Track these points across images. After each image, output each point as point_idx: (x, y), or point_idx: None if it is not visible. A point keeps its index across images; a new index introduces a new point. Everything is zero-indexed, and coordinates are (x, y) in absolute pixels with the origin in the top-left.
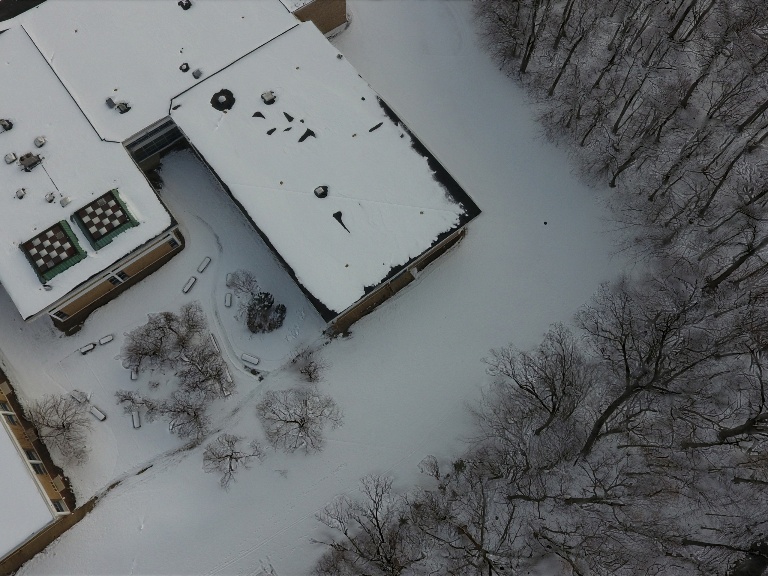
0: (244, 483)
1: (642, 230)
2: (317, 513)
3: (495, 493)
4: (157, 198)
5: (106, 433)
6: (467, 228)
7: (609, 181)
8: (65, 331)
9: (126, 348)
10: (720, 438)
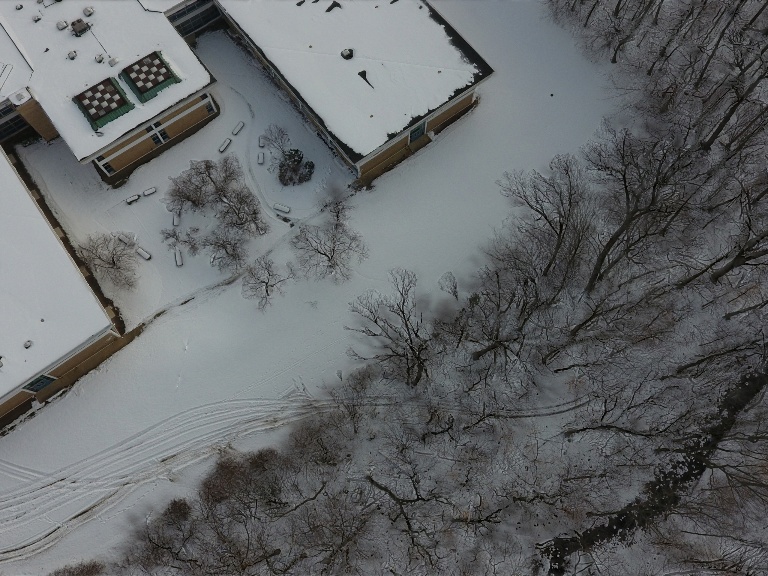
0: (278, 312)
1: (641, 98)
2: None
3: (507, 325)
4: (197, 59)
5: (151, 270)
6: (480, 98)
7: (611, 57)
8: (112, 184)
9: (169, 193)
10: (712, 280)
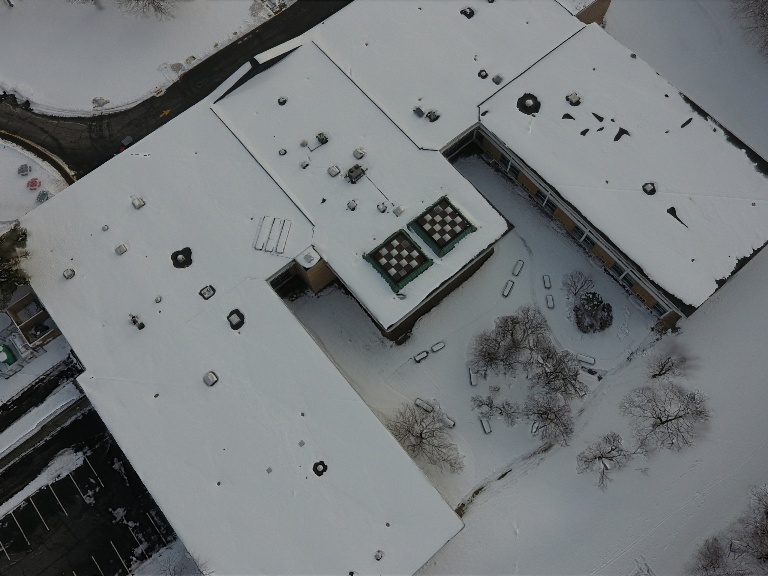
0: None
1: None
2: (767, 504)
3: None
4: (488, 203)
5: (459, 440)
6: None
7: None
8: (395, 340)
9: (472, 353)
10: None
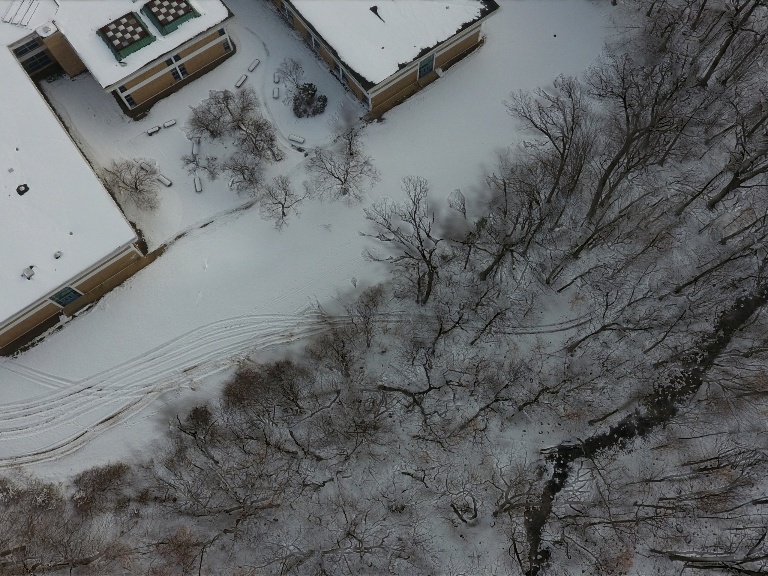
0: (294, 233)
1: (641, 37)
2: None
3: None
4: None
5: (172, 196)
6: (486, 38)
7: None
8: (133, 117)
9: (189, 123)
10: (709, 207)
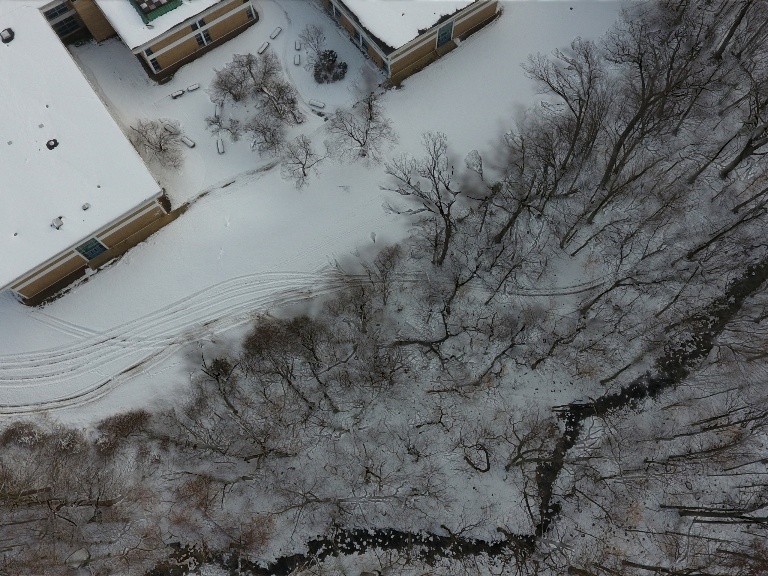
0: (313, 194)
1: (656, 11)
2: None
3: (527, 212)
4: None
5: (195, 156)
6: (503, 9)
7: None
8: (158, 81)
9: (213, 86)
10: (722, 177)
